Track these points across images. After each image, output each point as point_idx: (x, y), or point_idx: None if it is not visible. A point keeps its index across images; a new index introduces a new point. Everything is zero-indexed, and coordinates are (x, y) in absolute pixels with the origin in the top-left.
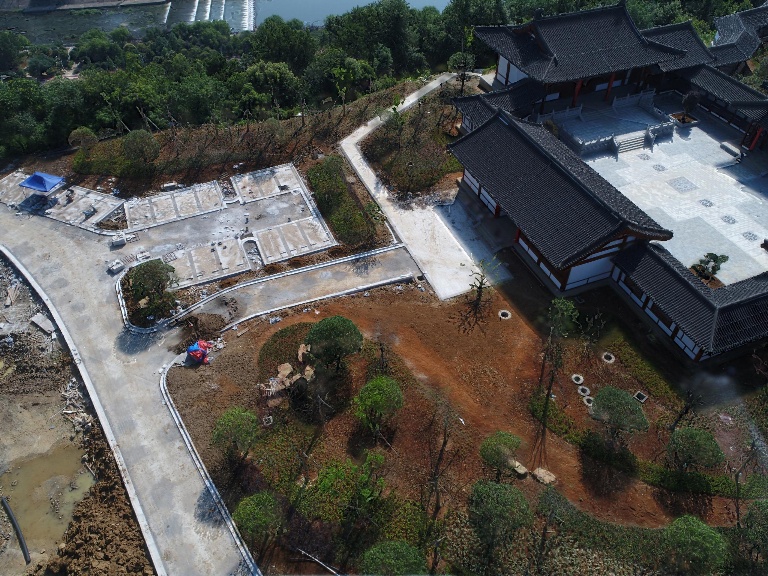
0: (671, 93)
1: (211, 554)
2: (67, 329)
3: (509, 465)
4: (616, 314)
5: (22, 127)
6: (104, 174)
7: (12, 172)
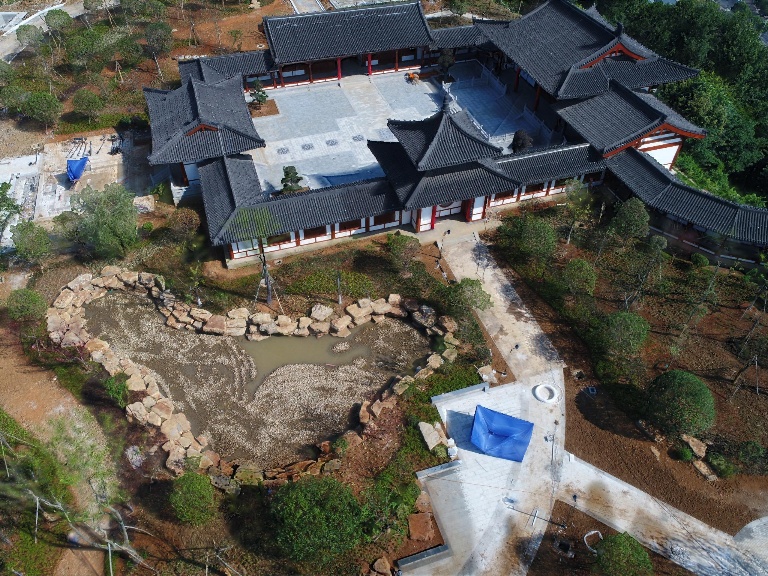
0: None
1: None
2: None
3: None
4: None
5: None
6: None
7: None
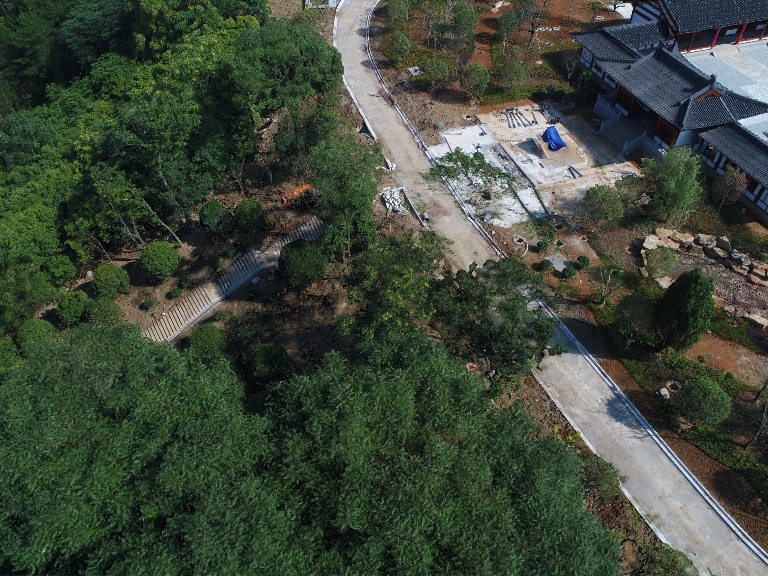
0: None
1: None
2: None
3: None
4: None
5: None
6: None
7: None
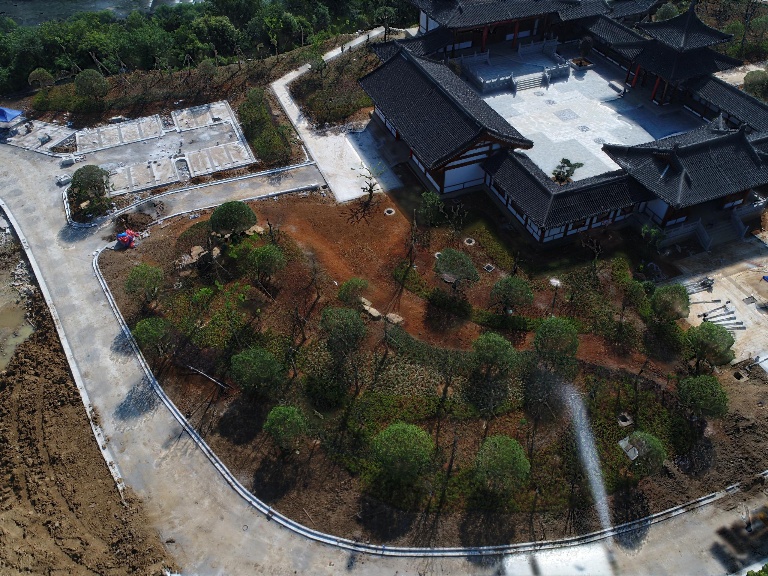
0: (576, 42)
1: (121, 373)
2: (19, 225)
3: (356, 300)
4: (484, 211)
5: None
6: (60, 110)
7: None
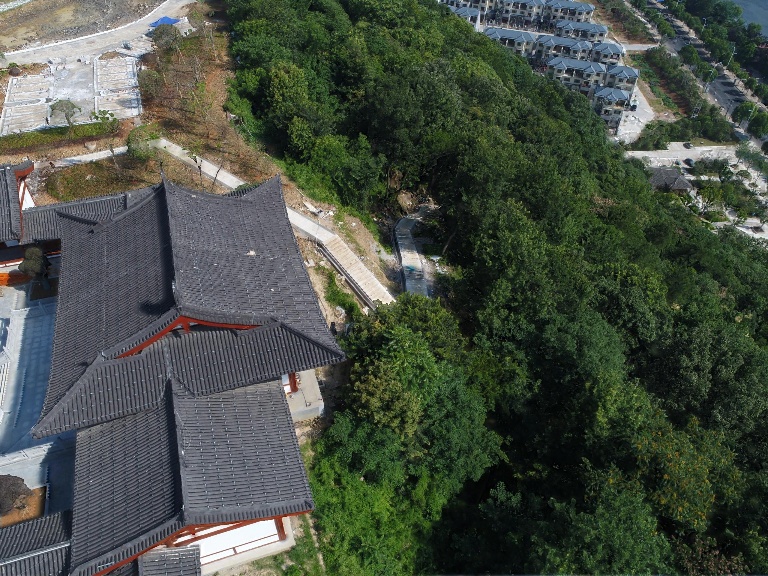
0: None
1: None
2: (8, 55)
3: None
4: None
5: (227, 1)
6: None
7: (209, 22)
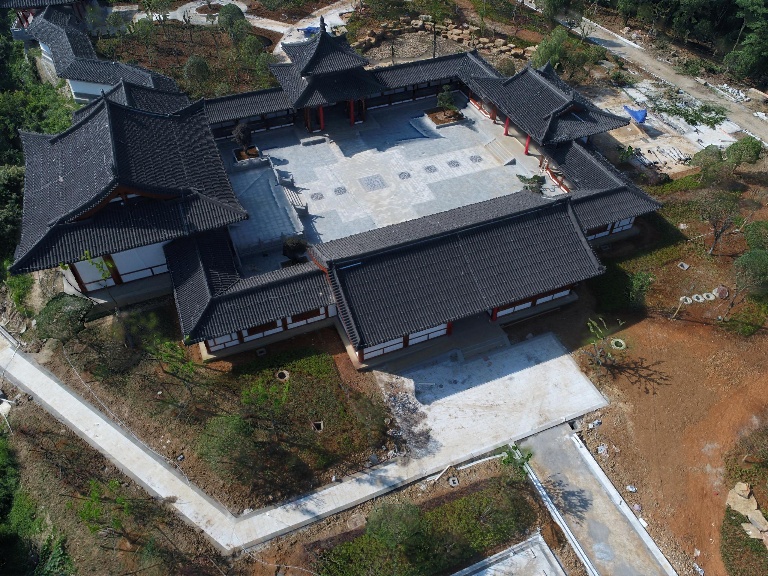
0: None
1: None
2: None
3: None
4: None
5: None
6: None
7: None
